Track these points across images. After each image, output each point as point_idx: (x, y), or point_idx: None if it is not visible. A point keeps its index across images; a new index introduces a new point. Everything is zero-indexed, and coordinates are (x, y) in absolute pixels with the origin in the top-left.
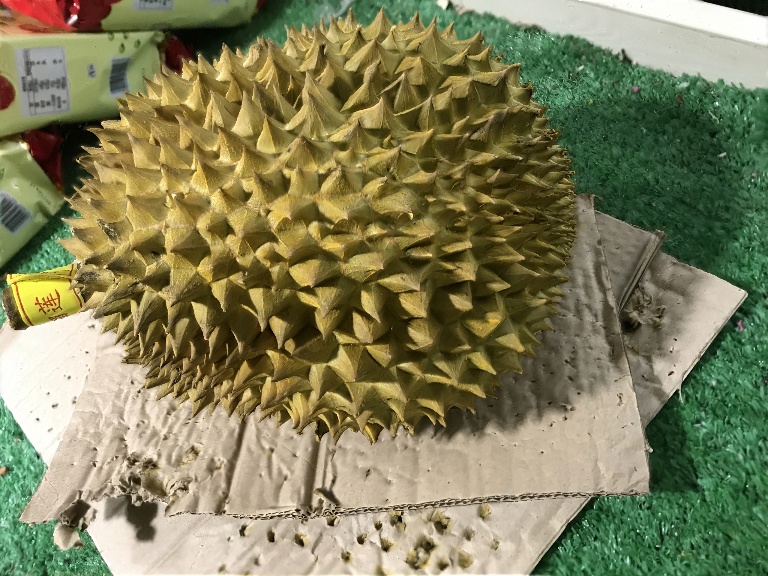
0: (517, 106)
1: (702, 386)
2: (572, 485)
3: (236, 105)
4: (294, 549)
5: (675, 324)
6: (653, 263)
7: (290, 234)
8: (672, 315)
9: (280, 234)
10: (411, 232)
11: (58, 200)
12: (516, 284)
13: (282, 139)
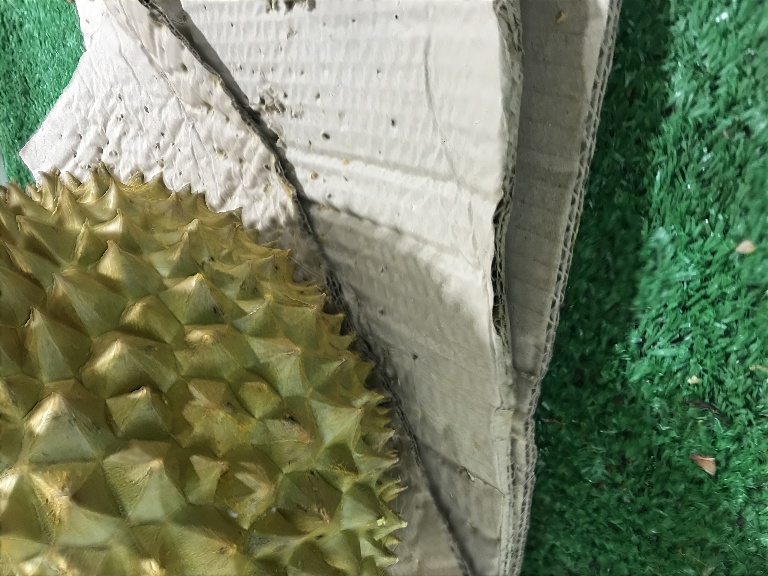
0: None
1: None
2: None
3: None
4: None
5: None
6: None
7: None
8: None
9: None
10: None
11: None
12: None
13: None
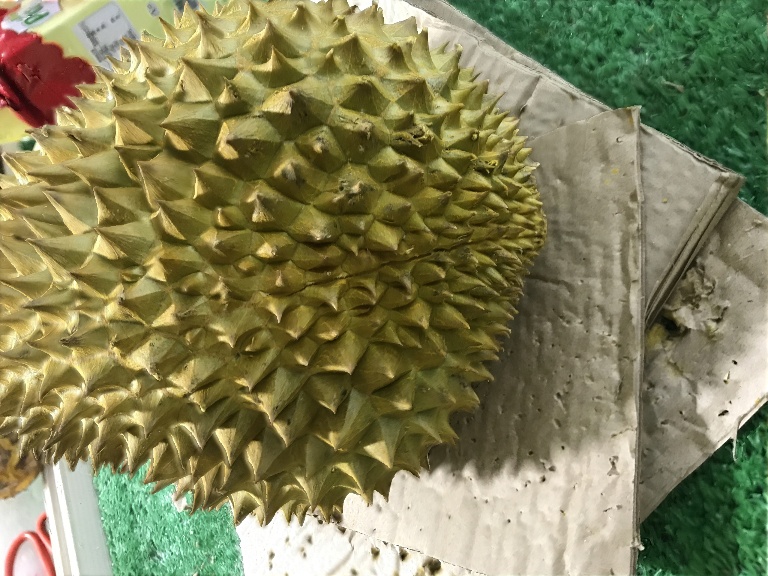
0: None
1: None
2: None
3: None
4: (336, 535)
5: (738, 337)
6: (724, 223)
7: (70, 396)
8: (736, 320)
9: (64, 396)
10: (179, 382)
11: None
12: (374, 384)
13: (36, 290)
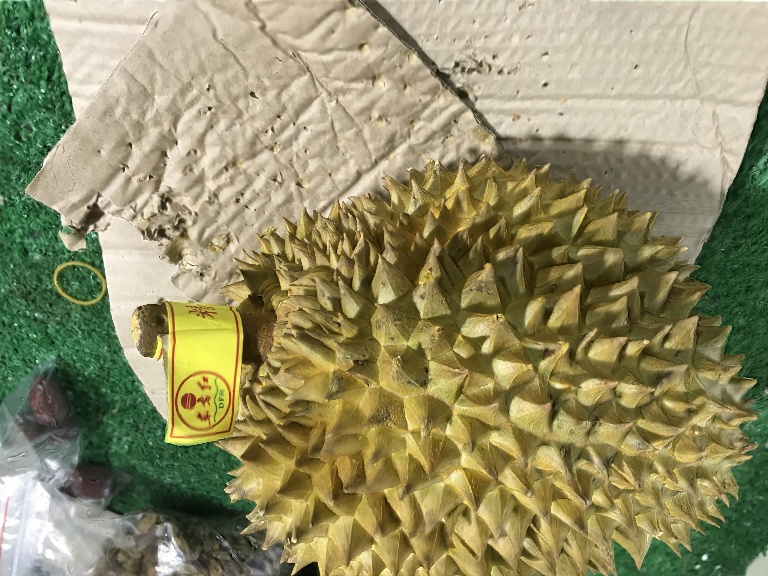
0: None
1: None
2: None
3: None
4: None
5: None
6: None
7: None
8: None
9: None
10: None
11: None
12: None
13: None
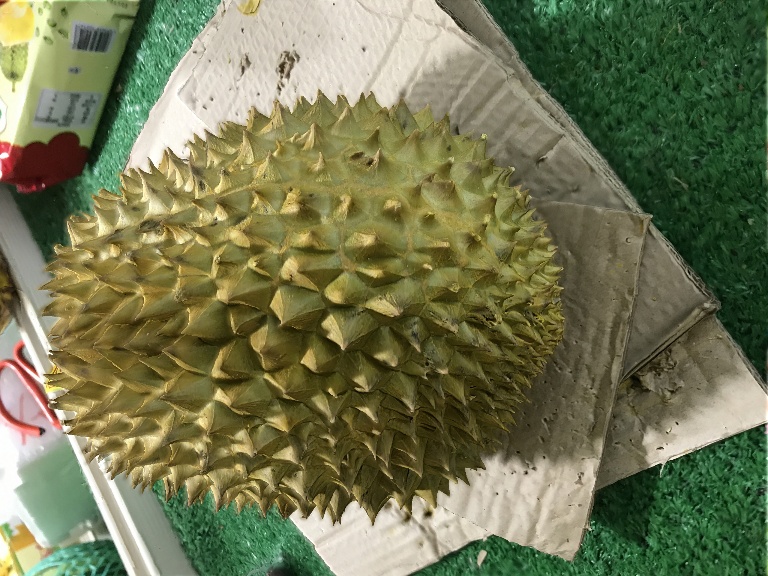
0: (416, 346)
1: (690, 468)
2: (509, 534)
3: (128, 333)
4: None
5: (684, 409)
6: (695, 326)
7: (191, 477)
8: (685, 398)
9: None
10: (291, 485)
11: (132, 1)
12: None
13: (159, 415)
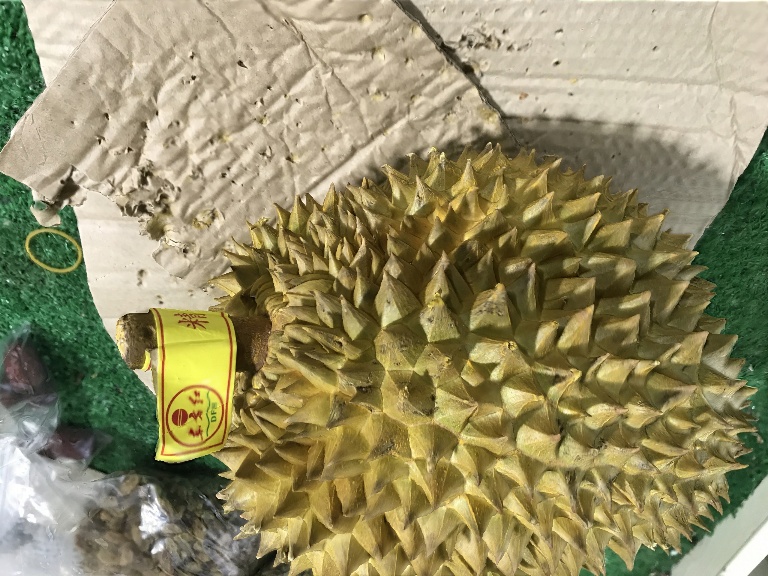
0: None
1: None
2: None
3: None
4: None
5: None
6: None
7: None
8: None
9: None
10: None
11: None
12: None
13: None
